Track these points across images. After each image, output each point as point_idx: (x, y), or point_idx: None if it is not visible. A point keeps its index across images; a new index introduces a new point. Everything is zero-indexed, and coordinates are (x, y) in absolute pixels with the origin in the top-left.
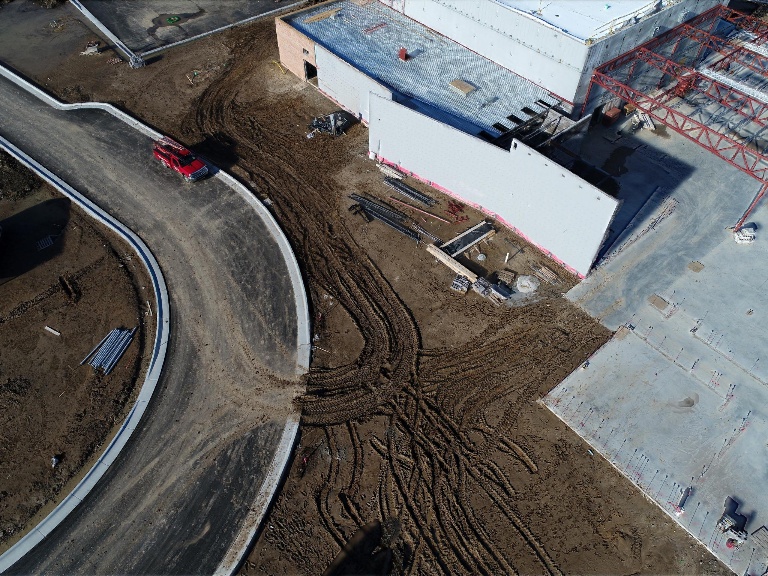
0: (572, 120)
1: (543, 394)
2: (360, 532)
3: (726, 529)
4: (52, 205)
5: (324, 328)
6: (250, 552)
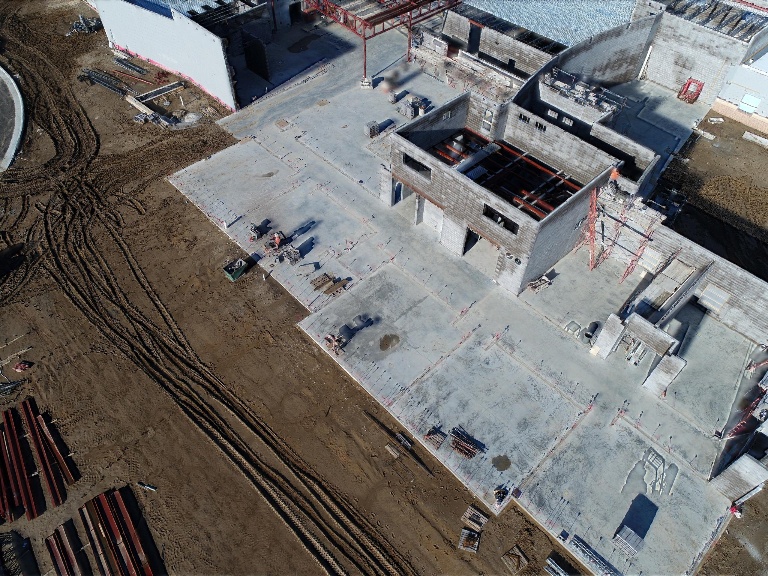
0: (250, 7)
1: None
2: (8, 248)
3: None
4: None
5: (29, 147)
6: None
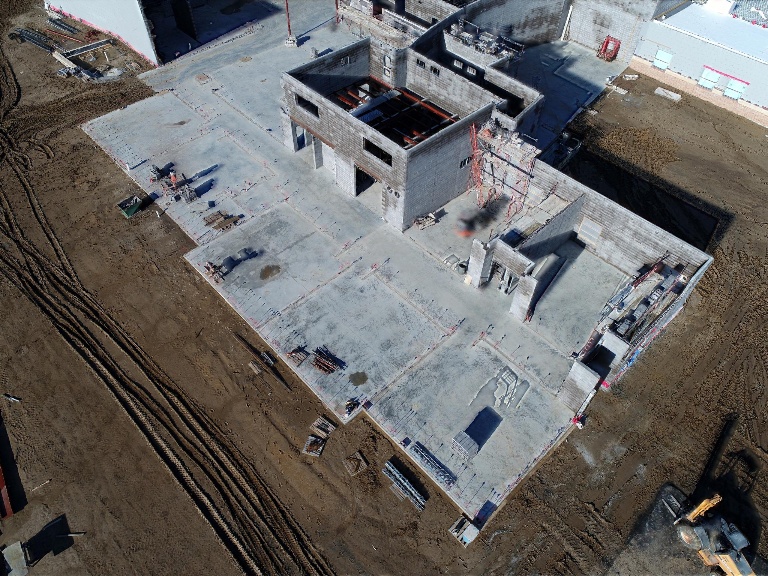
0: None
1: None
2: None
3: None
4: None
5: None
6: None
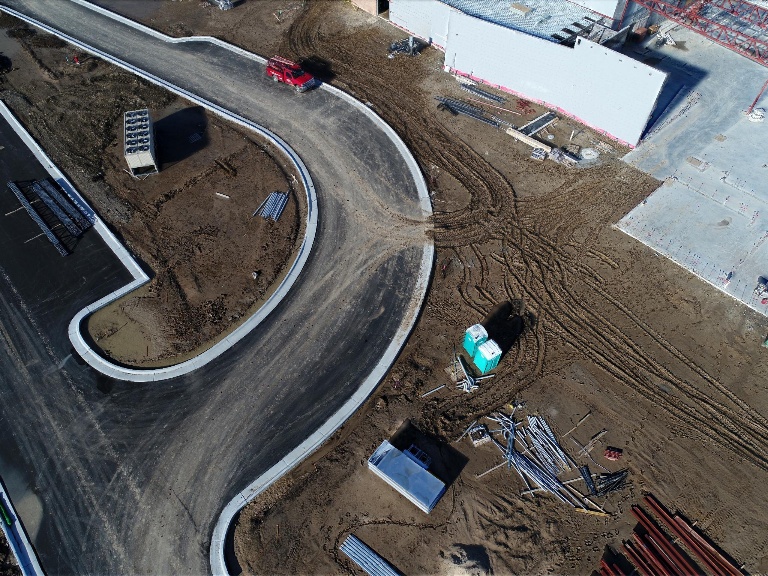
0: (614, 30)
1: (615, 222)
2: (496, 307)
3: (761, 293)
4: (190, 112)
5: (437, 187)
6: (418, 322)
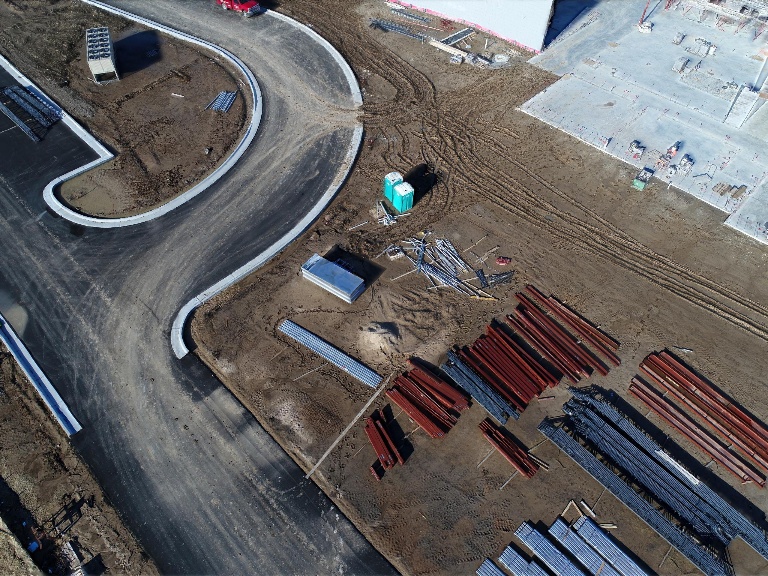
0: None
1: (518, 106)
2: (414, 168)
3: None
4: (147, 34)
5: (368, 85)
6: (348, 180)
